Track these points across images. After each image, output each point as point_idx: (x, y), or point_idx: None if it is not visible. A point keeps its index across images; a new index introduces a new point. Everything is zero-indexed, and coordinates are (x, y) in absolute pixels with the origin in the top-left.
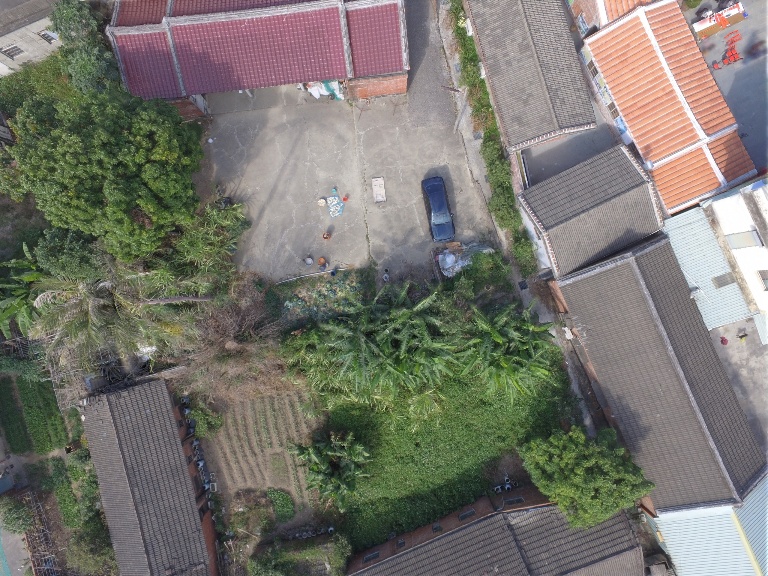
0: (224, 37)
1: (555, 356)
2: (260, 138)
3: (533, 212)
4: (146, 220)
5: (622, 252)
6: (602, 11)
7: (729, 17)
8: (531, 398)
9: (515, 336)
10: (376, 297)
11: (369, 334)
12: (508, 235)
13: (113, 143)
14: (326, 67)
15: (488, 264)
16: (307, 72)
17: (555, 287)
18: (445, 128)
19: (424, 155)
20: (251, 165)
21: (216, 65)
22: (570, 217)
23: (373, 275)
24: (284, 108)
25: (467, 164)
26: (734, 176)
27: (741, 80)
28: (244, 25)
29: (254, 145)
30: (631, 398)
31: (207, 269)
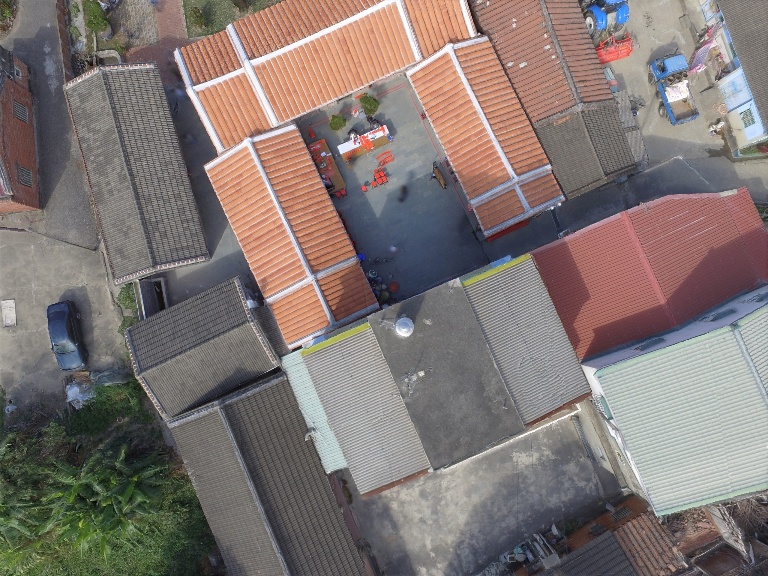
0: None
1: (191, 493)
2: None
3: (132, 352)
4: None
5: None
6: (214, 139)
7: (374, 140)
8: (163, 540)
9: (98, 490)
10: None
11: None
12: None
13: None
14: None
15: (119, 395)
16: None
17: None
18: None
19: (60, 276)
20: None
21: None
22: (166, 359)
23: (1, 405)
24: None
25: (107, 285)
26: (348, 313)
27: (393, 202)
28: None
29: None
30: (237, 551)
31: None
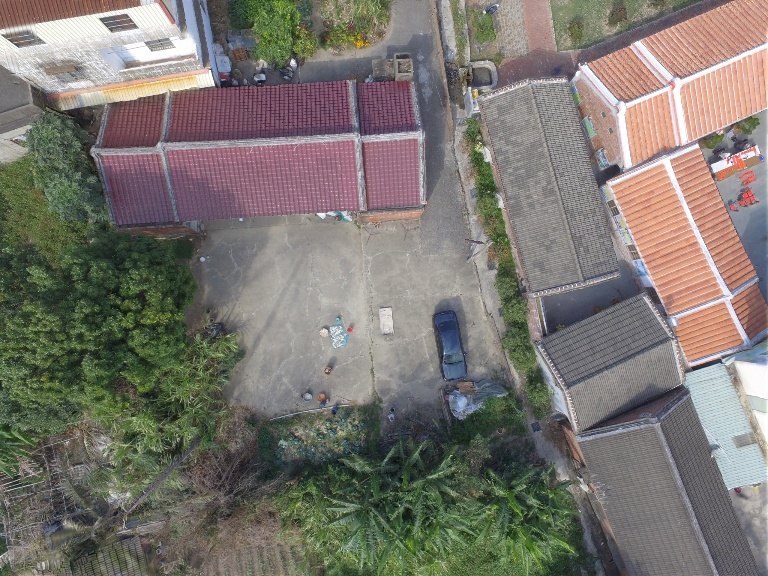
0: (226, 164)
1: (568, 505)
2: (258, 259)
3: (554, 365)
4: (131, 390)
5: (643, 406)
6: (627, 156)
7: (746, 160)
8: None
9: (534, 503)
10: (386, 459)
11: (377, 501)
12: (521, 373)
13: (96, 311)
14: (337, 199)
15: (501, 406)
16: (316, 203)
17: (572, 436)
18: (458, 257)
19: (436, 285)
20: (247, 288)
21: (215, 192)
22: (593, 373)
23: (377, 413)
24: (286, 227)
25: (480, 296)
26: (756, 332)
27: (756, 221)
28: (249, 153)
29: (251, 266)
30: (651, 565)
31: (194, 411)
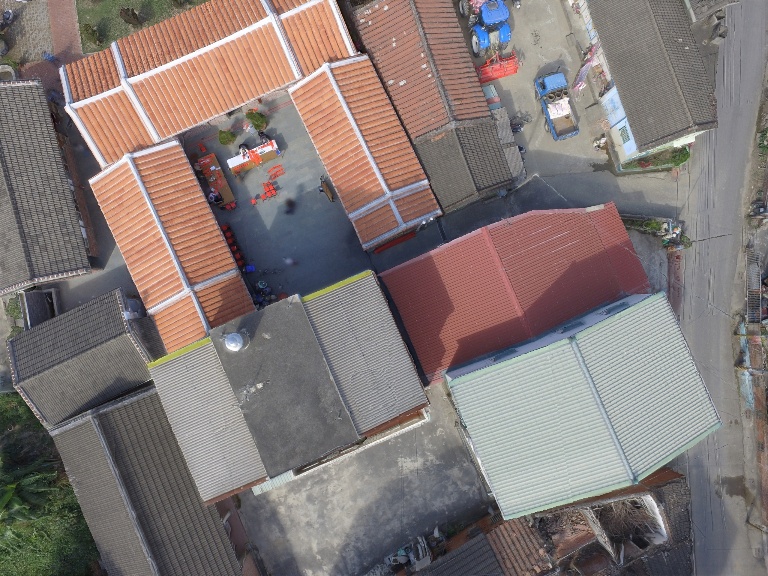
0: None
1: None
2: None
3: (11, 362)
4: None
5: None
6: (97, 154)
7: (262, 154)
8: (52, 545)
9: None
10: None
11: None
12: None
13: None
14: None
15: (9, 404)
16: None
17: None
18: None
19: None
20: None
21: None
22: (44, 369)
23: None
24: None
25: None
26: None
27: (283, 214)
28: None
29: None
30: (115, 555)
31: None
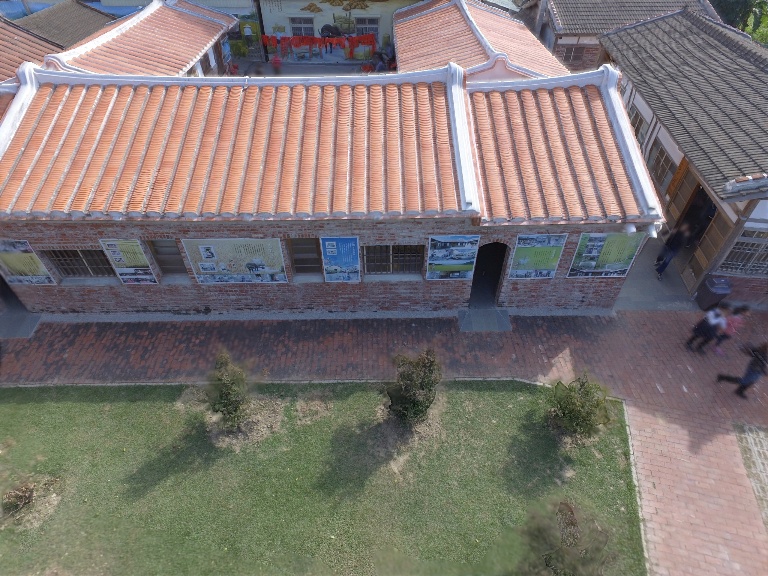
0: None
1: None
2: None
3: (711, 7)
4: None
5: None
6: None
7: None
8: None
9: None
10: None
11: None
12: None
13: None
14: None
15: None
16: None
17: None
18: None
19: None
20: None
21: None
22: None
23: None
24: None
25: None
26: (431, 2)
27: None
28: None
29: None
30: None
31: None
